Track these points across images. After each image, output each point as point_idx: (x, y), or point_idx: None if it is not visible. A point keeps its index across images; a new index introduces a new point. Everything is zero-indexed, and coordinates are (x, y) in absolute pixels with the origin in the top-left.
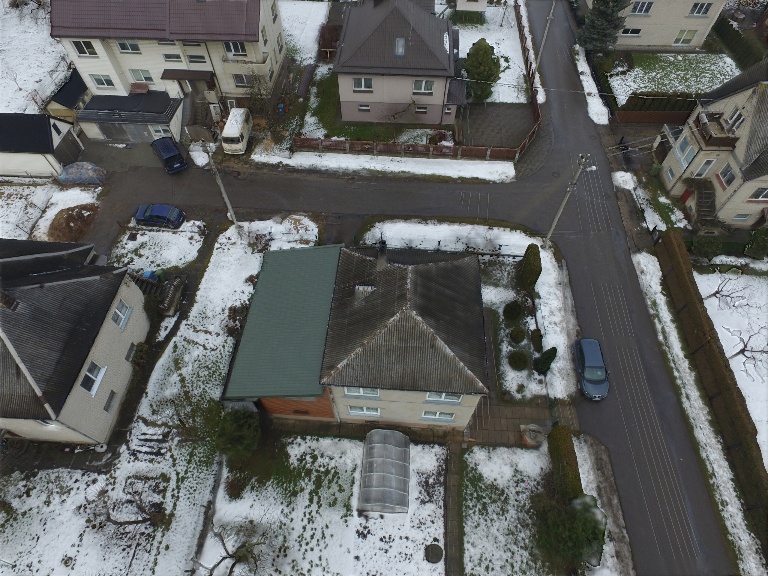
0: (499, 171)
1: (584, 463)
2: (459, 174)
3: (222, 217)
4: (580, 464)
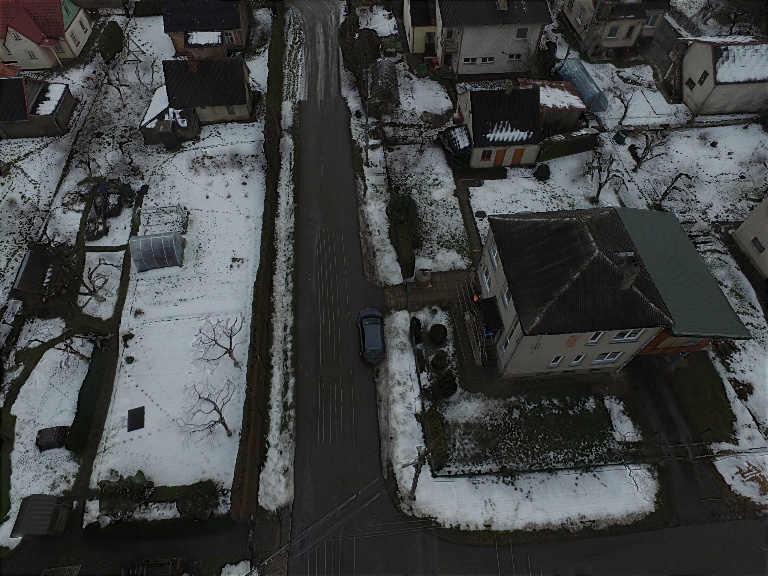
0: None
1: (383, 269)
2: None
3: None
4: (386, 268)
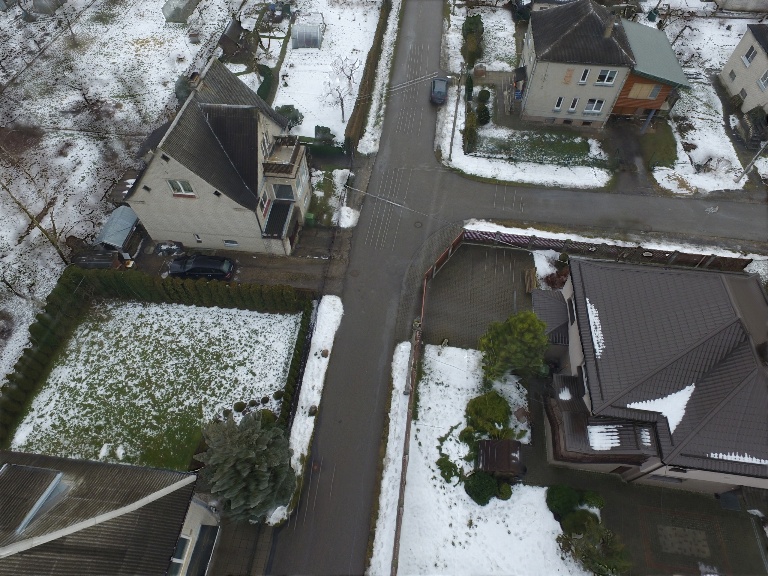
0: (483, 225)
1: (453, 66)
2: (526, 231)
3: (761, 195)
4: None
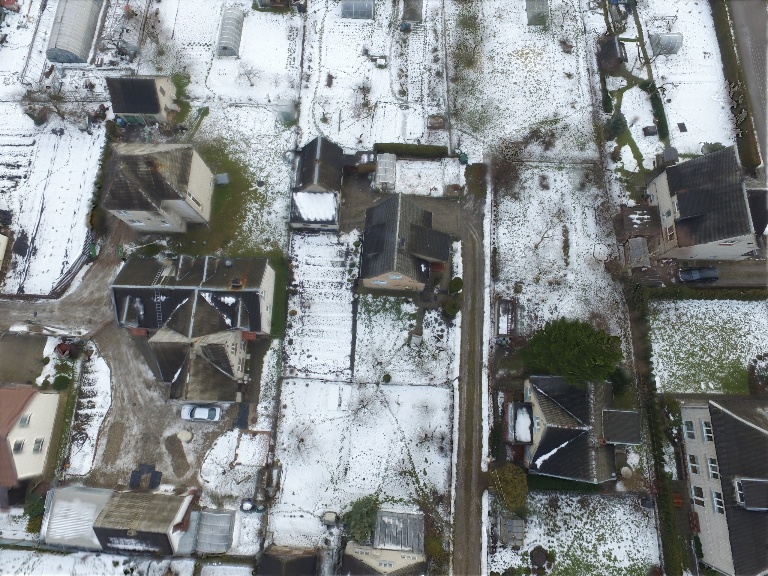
0: None
1: None
2: None
3: None
4: None
